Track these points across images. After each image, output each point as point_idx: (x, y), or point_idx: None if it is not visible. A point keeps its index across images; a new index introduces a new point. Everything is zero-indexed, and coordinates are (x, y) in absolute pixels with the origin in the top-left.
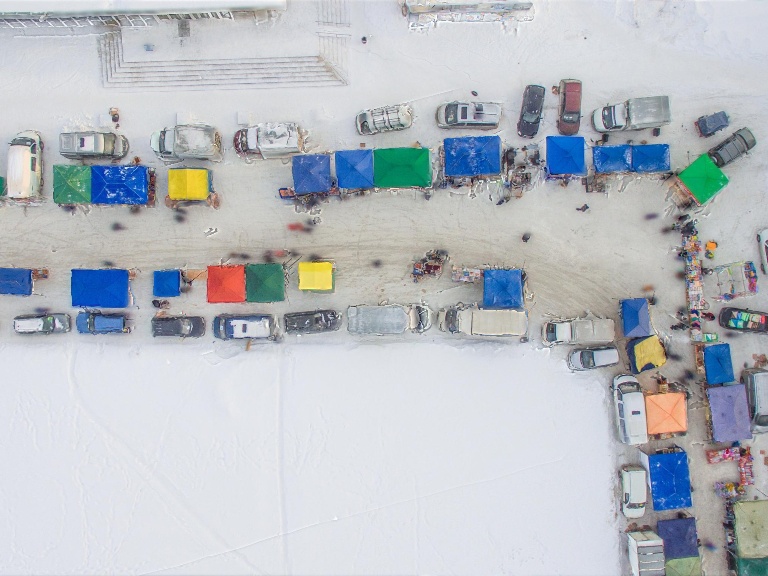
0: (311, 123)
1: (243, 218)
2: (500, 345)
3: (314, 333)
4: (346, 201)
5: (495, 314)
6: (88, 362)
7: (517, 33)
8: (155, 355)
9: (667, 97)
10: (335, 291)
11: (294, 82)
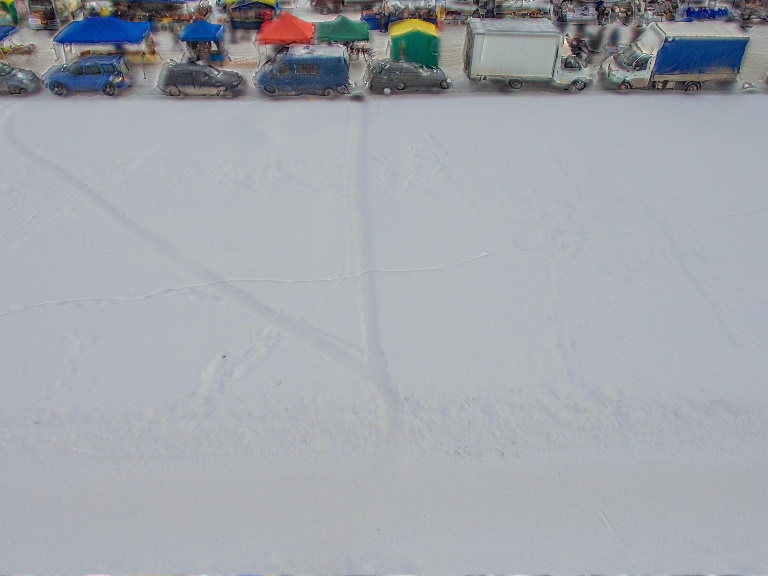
0: None
1: None
2: (713, 90)
3: (410, 87)
4: (444, 27)
5: (691, 23)
6: (36, 103)
7: None
8: (151, 98)
9: None
10: None
11: None
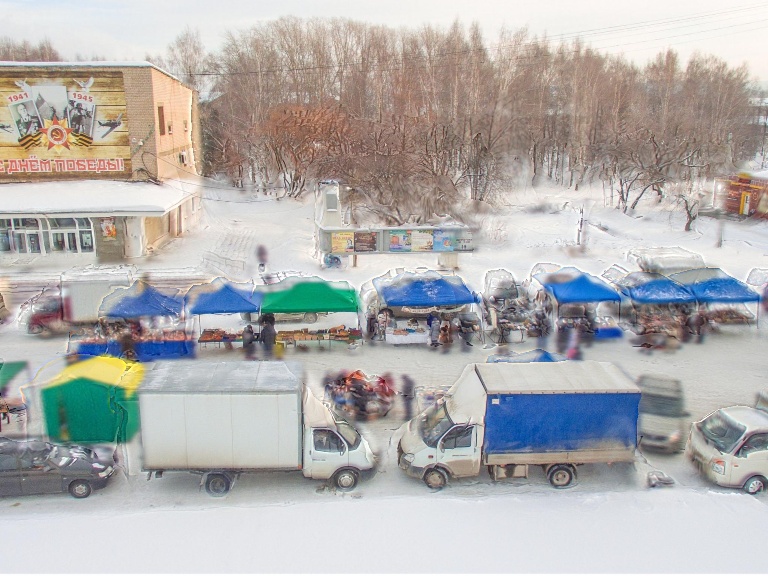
0: None
1: None
2: (593, 492)
3: (2, 498)
4: (194, 353)
5: (535, 365)
6: None
7: (458, 268)
8: None
9: None
10: (115, 439)
11: None
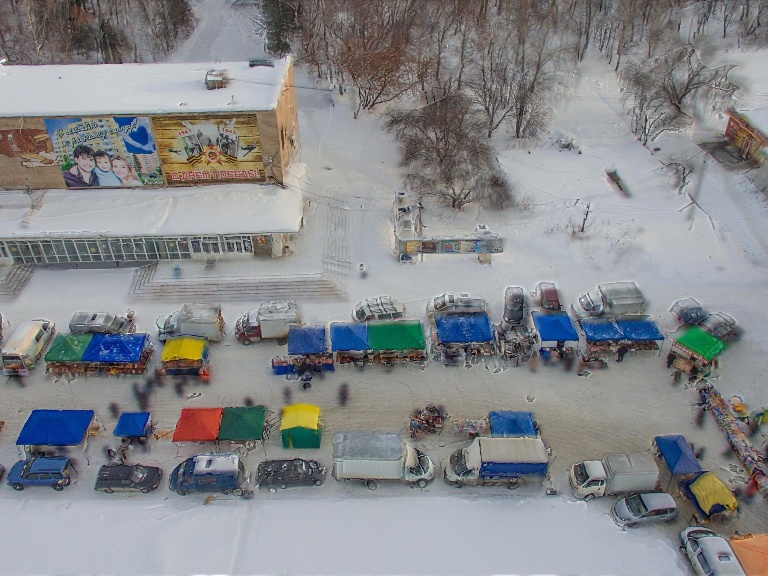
0: (310, 318)
1: (230, 385)
2: (522, 498)
3: (291, 487)
4: (339, 371)
5: (506, 441)
6: (1, 518)
7: (492, 265)
8: (88, 510)
9: (633, 282)
10: (320, 447)
11: (298, 292)
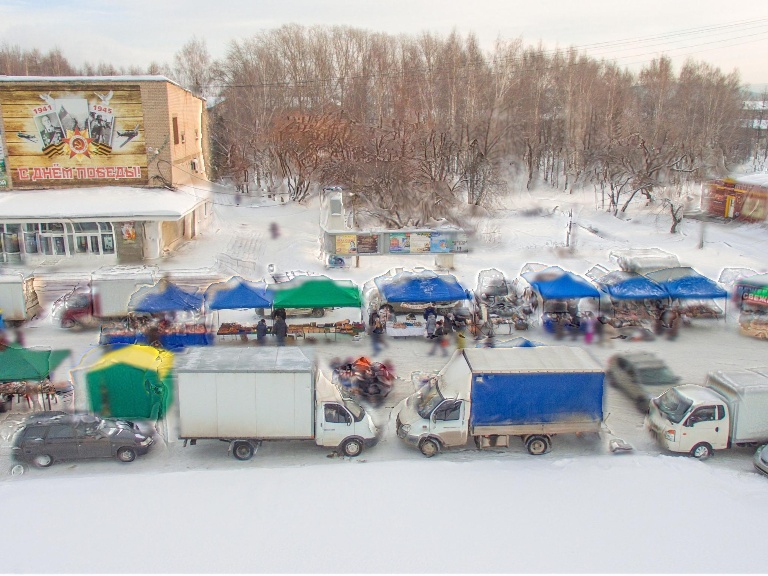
0: None
1: None
2: (562, 455)
3: (62, 461)
4: (214, 344)
5: (515, 349)
6: None
7: (454, 269)
8: None
9: None
10: (151, 415)
11: None
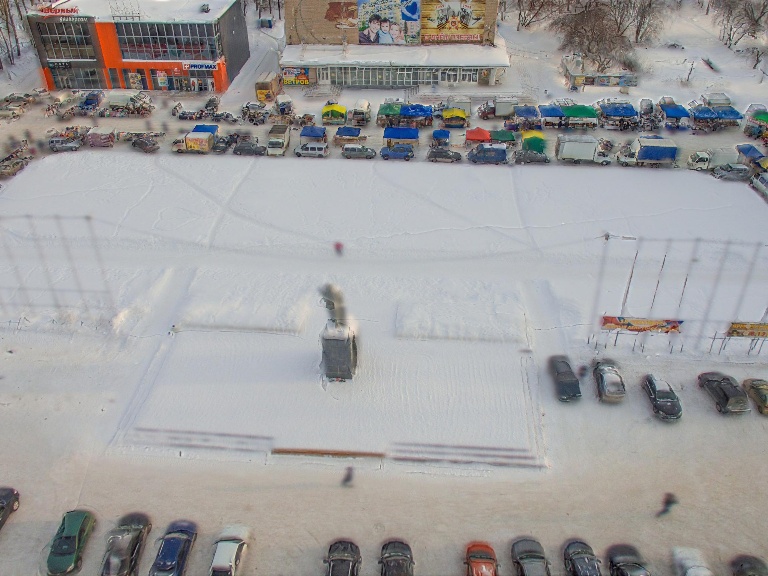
0: None
1: None
2: None
3: (533, 162)
4: (544, 129)
5: (653, 139)
6: (385, 164)
7: (629, 94)
8: None
9: (723, 93)
10: (543, 152)
11: None
